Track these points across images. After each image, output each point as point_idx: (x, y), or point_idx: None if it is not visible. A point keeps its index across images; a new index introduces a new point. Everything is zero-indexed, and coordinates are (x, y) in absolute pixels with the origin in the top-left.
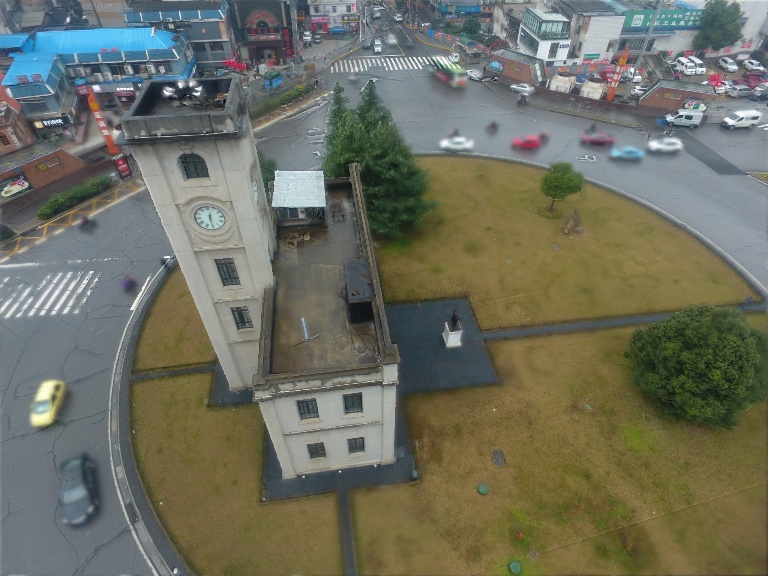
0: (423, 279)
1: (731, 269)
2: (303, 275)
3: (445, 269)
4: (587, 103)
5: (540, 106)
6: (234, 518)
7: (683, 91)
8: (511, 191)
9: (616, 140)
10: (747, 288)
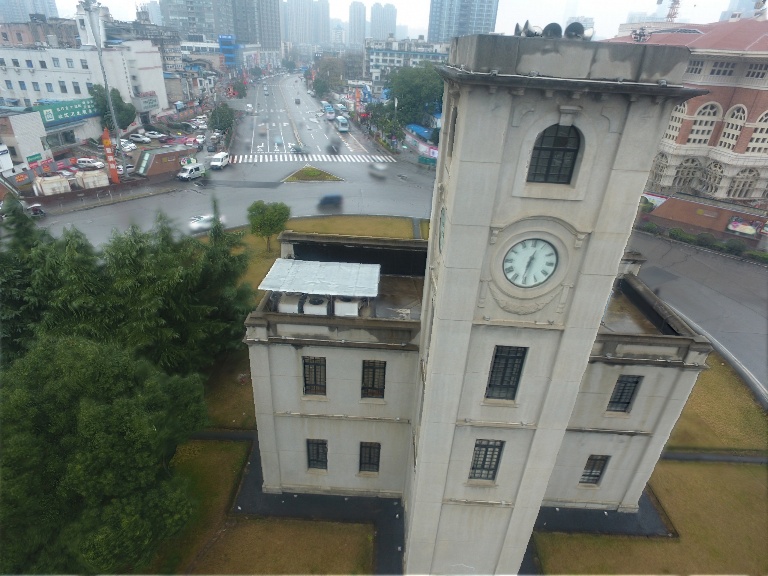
0: None
1: (379, 217)
2: None
3: None
4: (100, 193)
5: (65, 211)
6: (713, 569)
7: (173, 152)
8: None
9: (183, 202)
10: (398, 219)
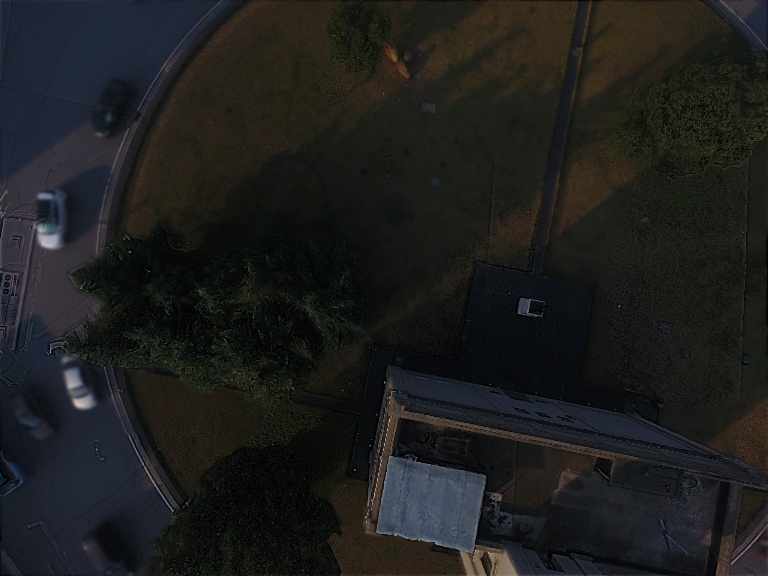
0: (430, 300)
1: None
2: (567, 517)
3: (423, 266)
4: None
5: None
6: None
7: None
8: (289, 92)
9: None
10: None
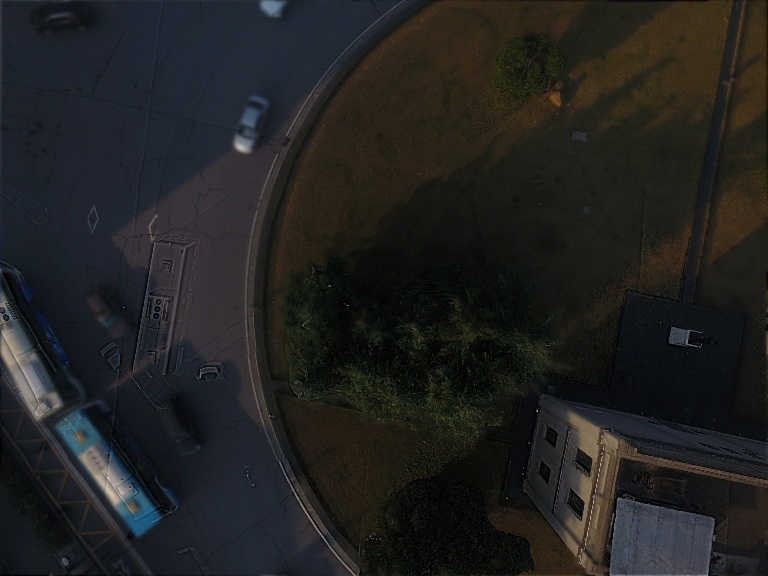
0: (582, 328)
1: None
2: None
3: (575, 295)
4: None
5: None
6: None
7: None
8: (440, 119)
9: None
10: None
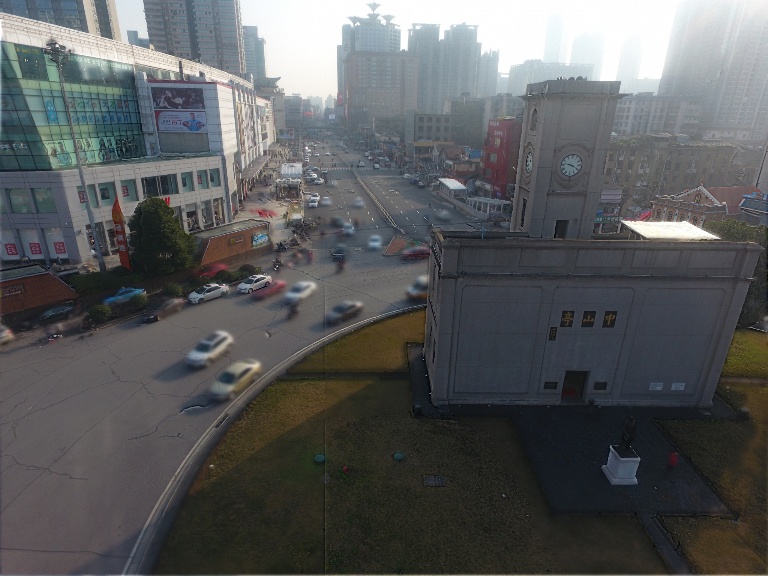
0: (741, 464)
1: None
2: None
3: None
4: None
5: None
6: (397, 334)
7: None
8: None
9: None
10: None
